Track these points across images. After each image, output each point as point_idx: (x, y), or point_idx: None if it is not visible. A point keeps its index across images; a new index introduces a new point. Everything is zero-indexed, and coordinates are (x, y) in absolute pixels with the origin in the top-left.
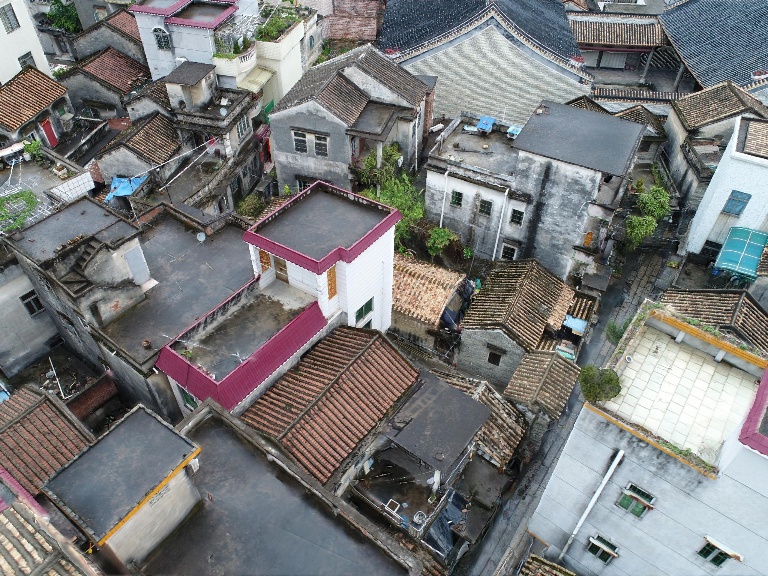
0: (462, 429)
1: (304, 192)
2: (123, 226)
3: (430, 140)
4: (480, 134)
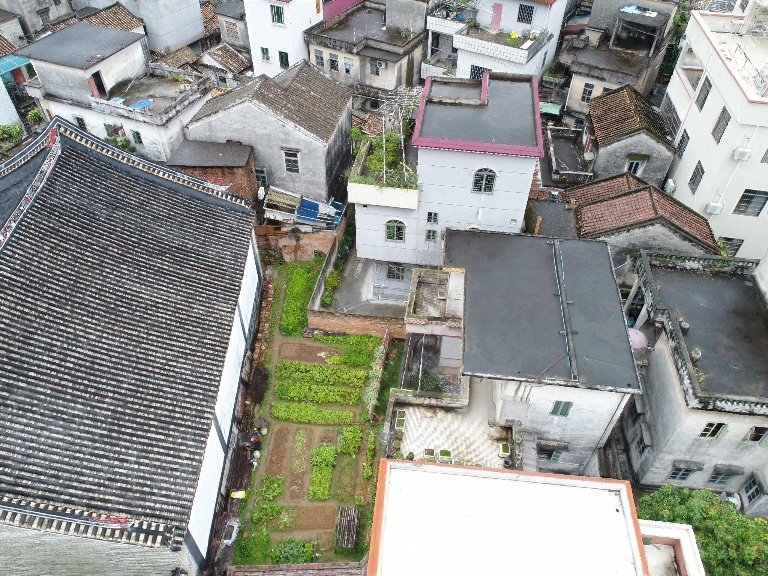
0: (226, 6)
1: None
2: None
3: None
4: None
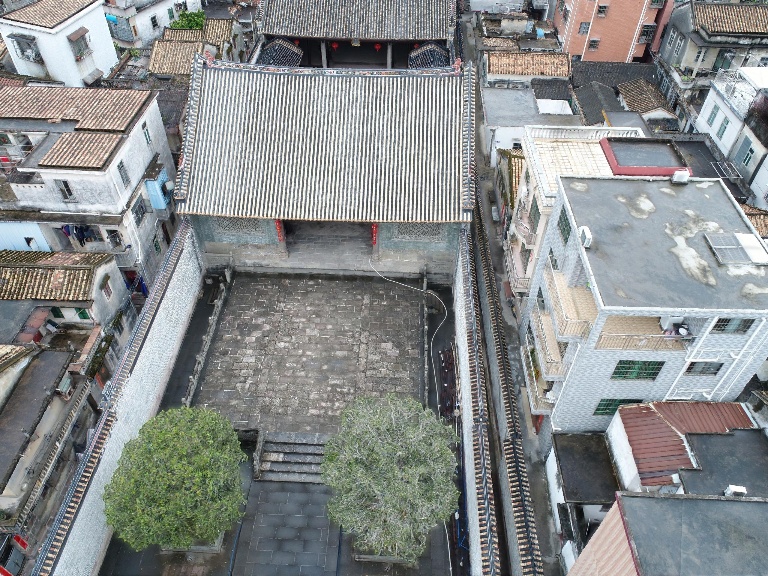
0: None
1: None
2: None
3: (231, 4)
4: None
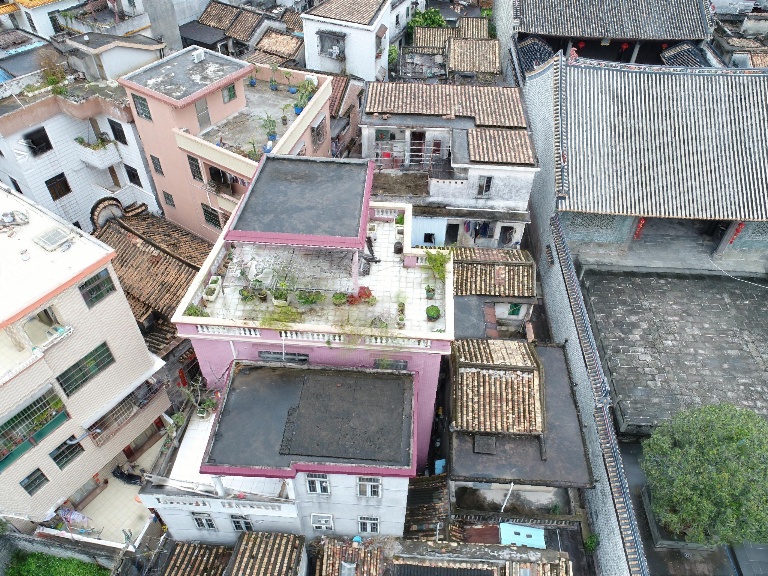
0: None
1: None
2: None
3: (449, 3)
4: None
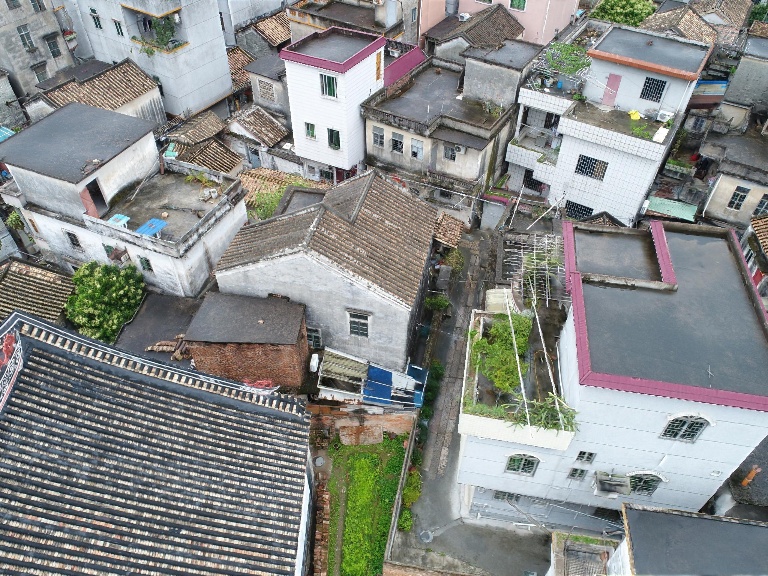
0: None
1: (352, 57)
2: (475, 55)
3: None
4: (162, 236)
